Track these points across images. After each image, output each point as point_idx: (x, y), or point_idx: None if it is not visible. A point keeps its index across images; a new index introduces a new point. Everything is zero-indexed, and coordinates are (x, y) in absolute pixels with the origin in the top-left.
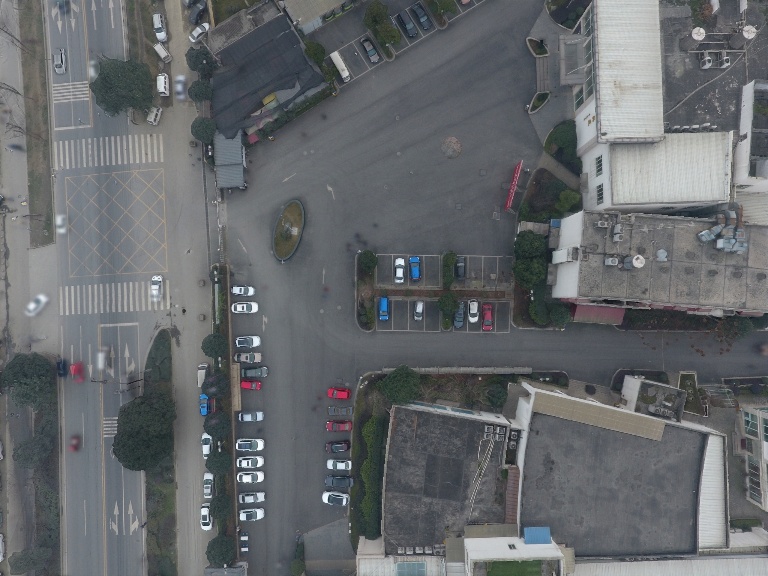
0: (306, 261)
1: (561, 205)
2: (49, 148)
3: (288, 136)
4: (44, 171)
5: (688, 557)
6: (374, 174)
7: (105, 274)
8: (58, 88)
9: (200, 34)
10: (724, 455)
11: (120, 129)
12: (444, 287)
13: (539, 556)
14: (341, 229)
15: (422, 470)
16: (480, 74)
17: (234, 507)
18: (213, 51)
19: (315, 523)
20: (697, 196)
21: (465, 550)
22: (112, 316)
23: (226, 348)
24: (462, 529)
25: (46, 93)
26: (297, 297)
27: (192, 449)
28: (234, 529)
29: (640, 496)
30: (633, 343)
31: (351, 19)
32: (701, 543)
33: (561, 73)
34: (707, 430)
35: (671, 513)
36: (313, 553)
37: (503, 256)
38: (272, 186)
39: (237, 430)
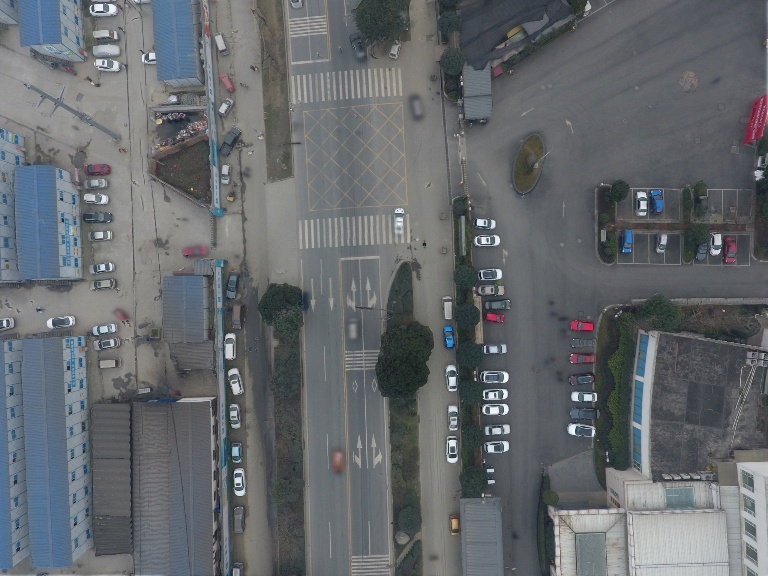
0: (546, 195)
1: None
2: (287, 82)
3: (526, 71)
4: (282, 105)
5: None
6: (612, 108)
7: (345, 207)
8: (295, 22)
9: None
10: None
11: (359, 63)
12: (685, 220)
13: None
14: (580, 163)
15: (684, 397)
16: (717, 9)
17: None
18: None
19: (559, 456)
20: None
21: (739, 473)
22: (353, 249)
23: (477, 279)
24: (725, 456)
25: (283, 27)
26: (537, 230)
27: (434, 382)
28: None
29: None
30: None
31: None
32: None
33: None
34: None
35: None
36: (558, 485)
37: (742, 190)
38: (511, 120)
39: None
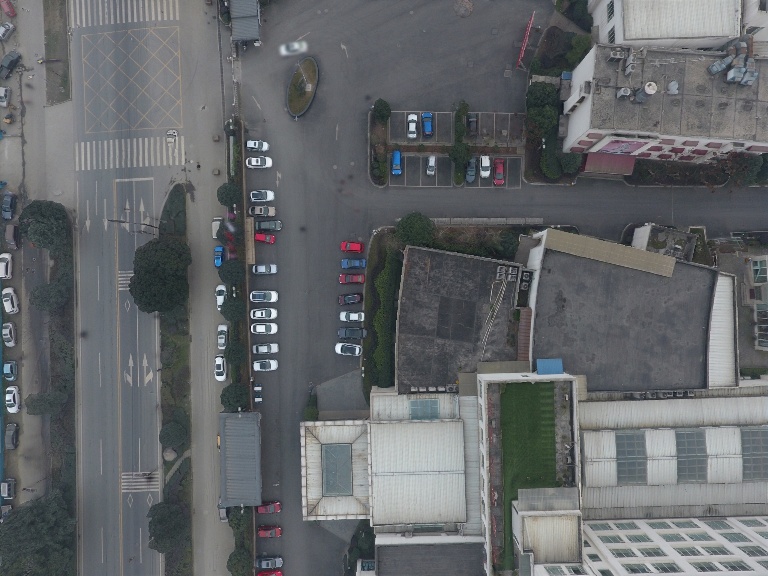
0: (320, 118)
1: (573, 52)
2: (66, 6)
3: None
4: (61, 29)
5: None
6: (387, 33)
7: (121, 130)
8: None
9: None
10: (734, 295)
11: None
12: (456, 143)
13: (552, 378)
14: (354, 87)
15: (435, 312)
16: None
17: (248, 359)
18: None
19: (328, 375)
20: (708, 32)
21: (478, 384)
22: (127, 171)
23: (241, 197)
24: (474, 370)
25: None
26: (311, 153)
27: (206, 302)
28: (248, 380)
29: (651, 333)
30: (643, 198)
31: None
32: (711, 382)
33: None
34: None
35: (681, 350)
36: (326, 404)
37: None
38: (286, 44)
39: (251, 284)
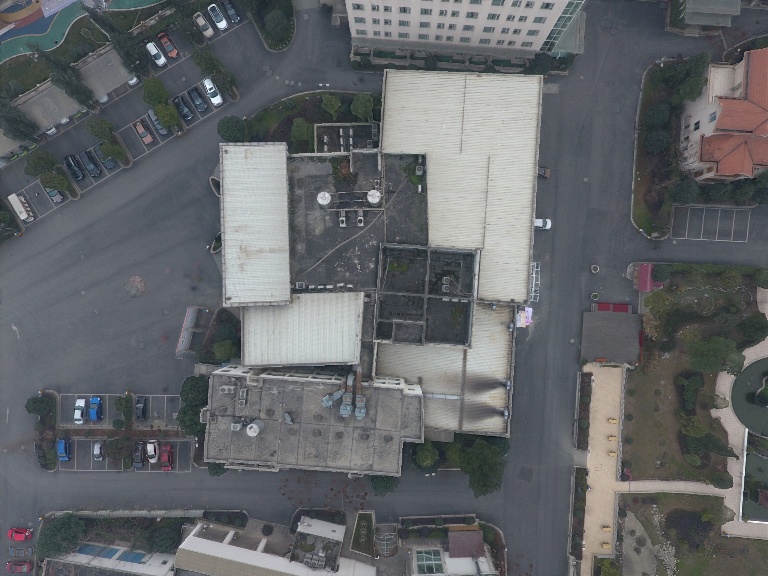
0: None
1: None
2: None
3: None
4: None
5: None
6: (59, 313)
7: None
8: None
9: None
10: None
11: None
12: (126, 427)
13: None
14: (25, 368)
15: None
16: (164, 213)
17: None
18: None
19: None
20: (328, 357)
21: None
22: None
23: None
24: None
25: None
26: None
27: None
28: None
29: None
30: (313, 482)
31: None
32: None
33: None
34: None
35: None
36: None
37: None
38: None
39: None
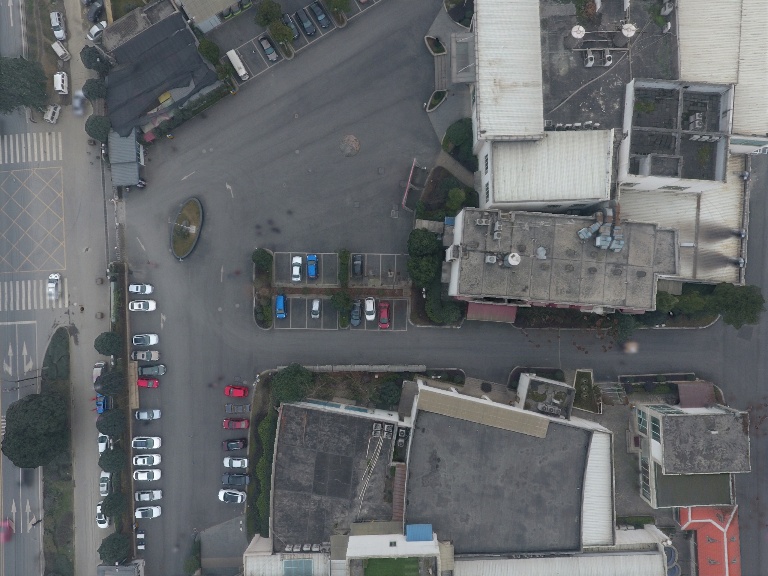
0: (204, 259)
1: (451, 203)
2: None
3: (187, 134)
4: None
5: (576, 554)
6: (273, 172)
7: (3, 272)
8: None
9: (98, 32)
10: (611, 452)
11: (18, 127)
12: (342, 285)
13: (414, 553)
14: (240, 227)
15: (311, 468)
16: (379, 72)
17: (131, 505)
18: (108, 49)
19: (212, 521)
20: (578, 194)
21: None
22: (10, 314)
23: (120, 346)
24: None
25: None
26: (195, 295)
27: (90, 447)
28: (130, 527)
29: (525, 493)
30: None
31: (250, 17)
32: (587, 540)
33: (452, 71)
34: (594, 427)
35: (556, 510)
36: (210, 551)
37: (401, 254)
38: (171, 184)
39: (135, 428)
